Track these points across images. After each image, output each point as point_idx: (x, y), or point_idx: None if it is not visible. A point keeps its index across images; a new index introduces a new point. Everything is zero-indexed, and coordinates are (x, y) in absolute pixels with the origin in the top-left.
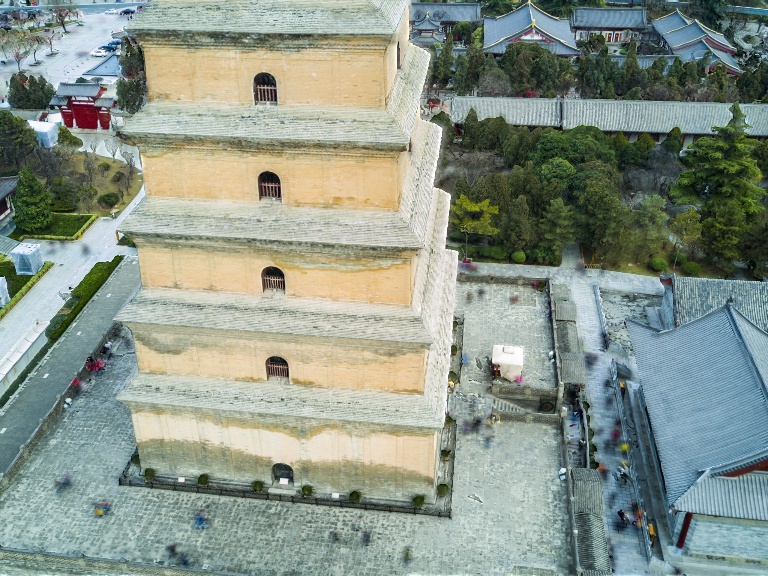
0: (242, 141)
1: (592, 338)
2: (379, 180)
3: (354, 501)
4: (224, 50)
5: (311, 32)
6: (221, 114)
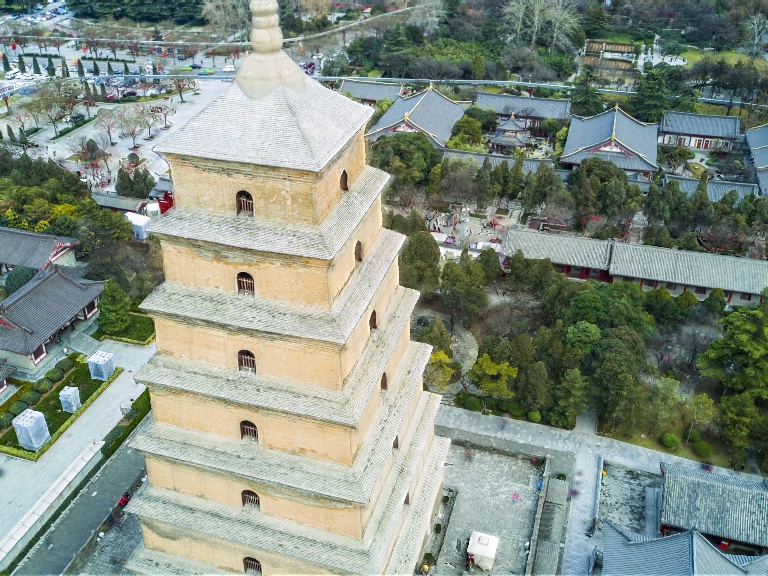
0: (226, 399)
1: (582, 519)
2: (335, 443)
3: None
4: (215, 330)
5: (280, 332)
6: (212, 375)
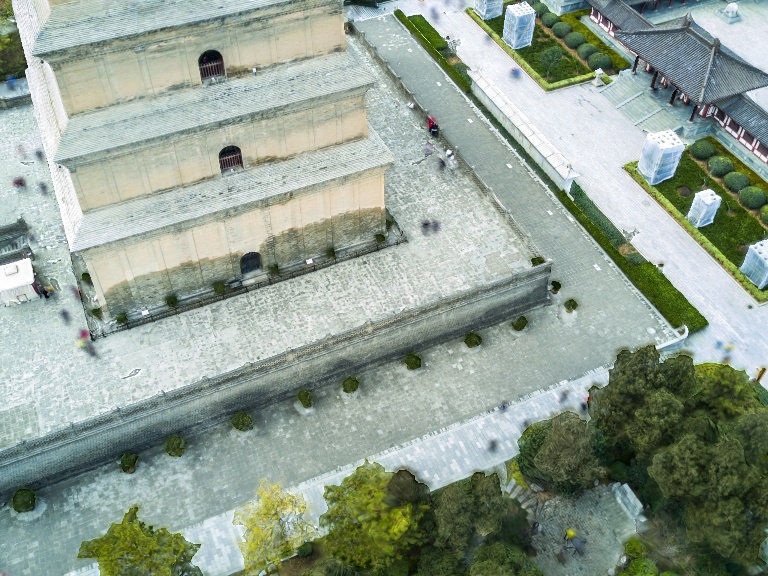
0: None
1: None
2: None
3: None
4: None
5: None
6: None
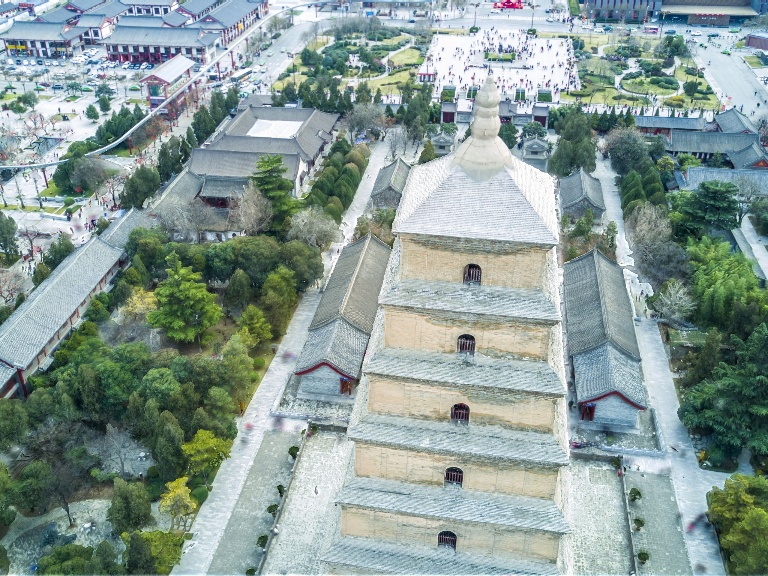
0: None
1: None
2: None
3: None
4: None
5: None
6: None
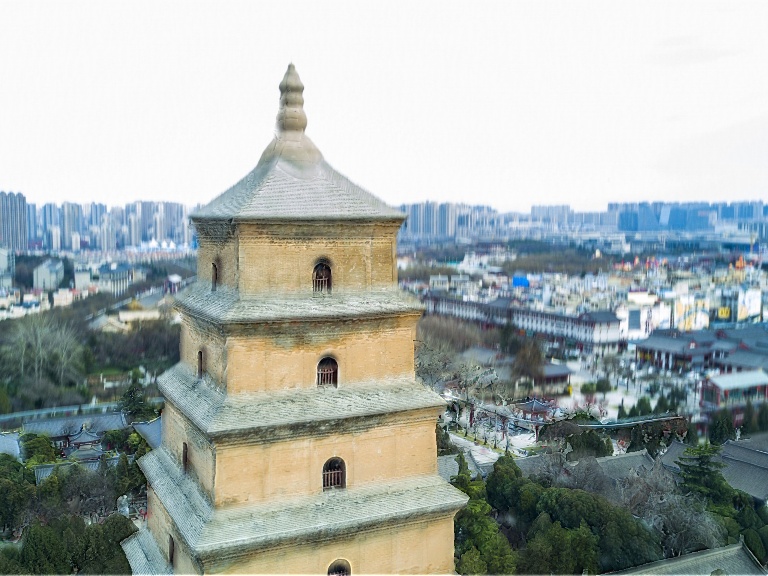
0: (322, 530)
1: None
2: (440, 542)
3: None
4: (299, 441)
5: (384, 411)
6: (295, 507)
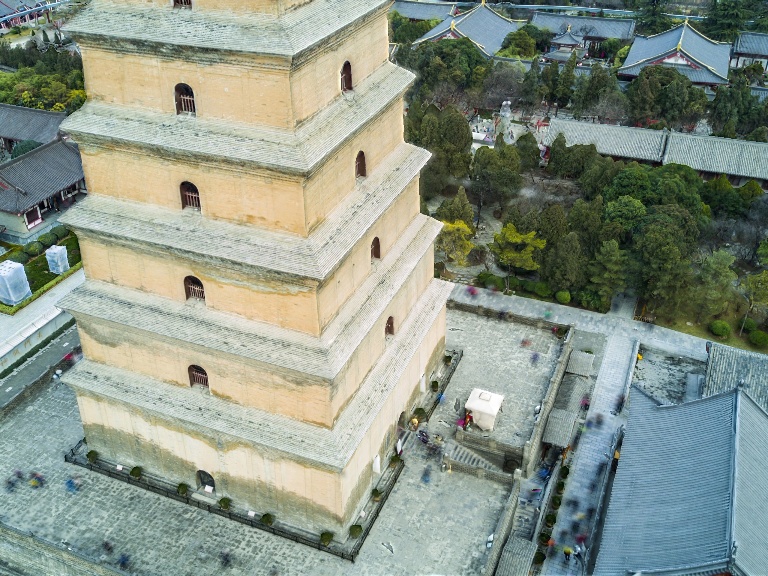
0: (160, 149)
1: (608, 398)
2: (287, 203)
3: (263, 523)
4: (147, 58)
5: (218, 47)
6: (145, 120)
